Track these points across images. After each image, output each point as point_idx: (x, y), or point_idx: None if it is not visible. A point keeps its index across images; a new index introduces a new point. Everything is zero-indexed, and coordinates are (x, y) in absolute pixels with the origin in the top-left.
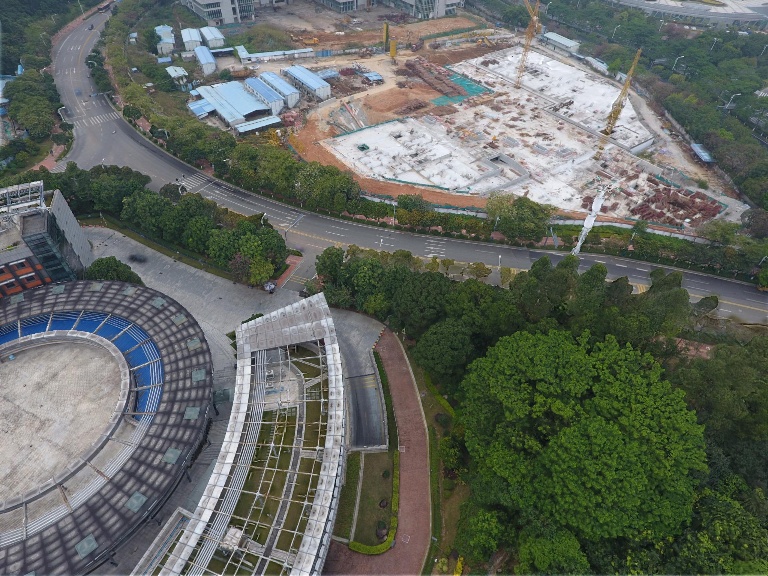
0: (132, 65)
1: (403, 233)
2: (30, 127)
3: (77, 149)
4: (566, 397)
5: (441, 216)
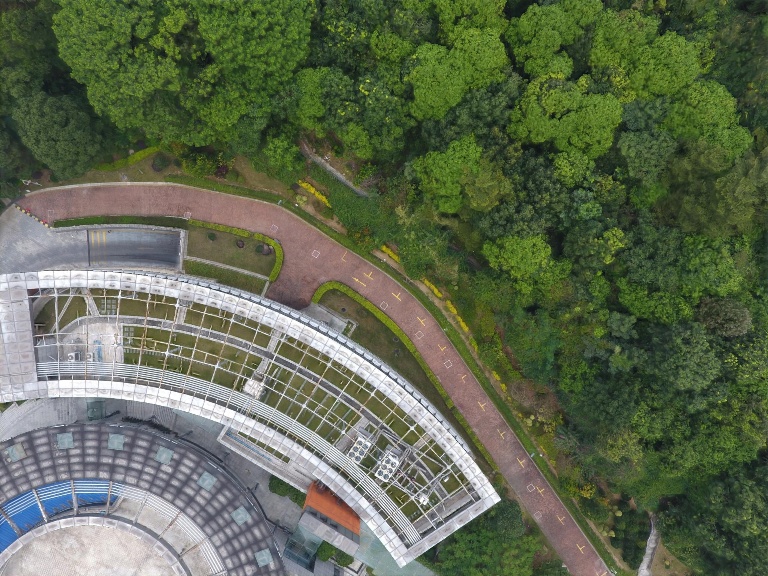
0: None
1: None
2: None
3: None
4: (160, 8)
5: None
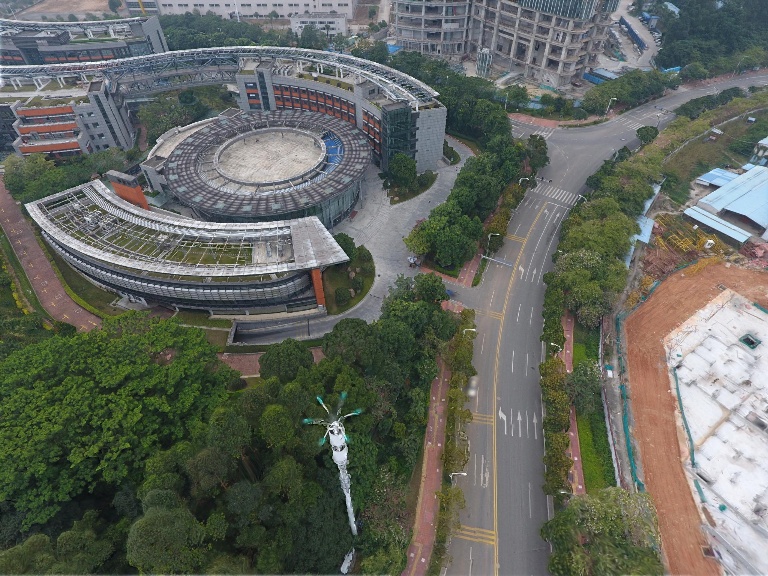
0: (759, 116)
1: None
2: (585, 98)
3: (583, 130)
4: None
5: None
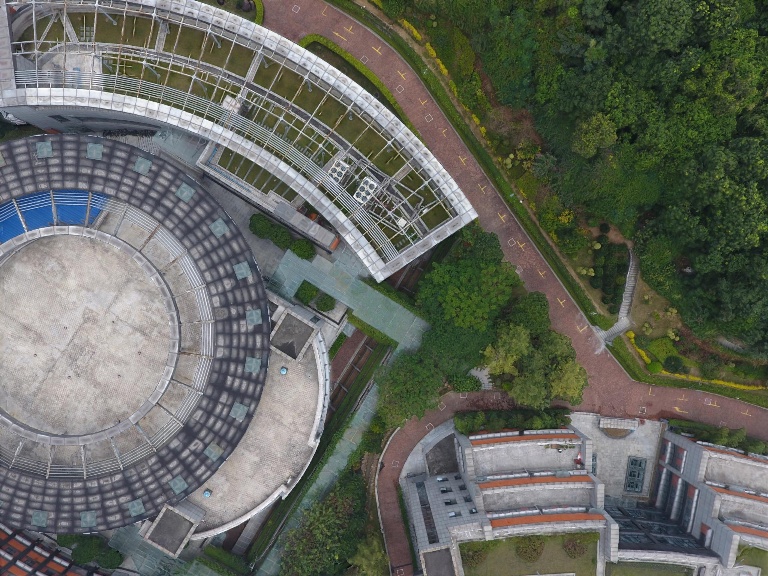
0: None
1: None
2: None
3: None
4: None
5: None
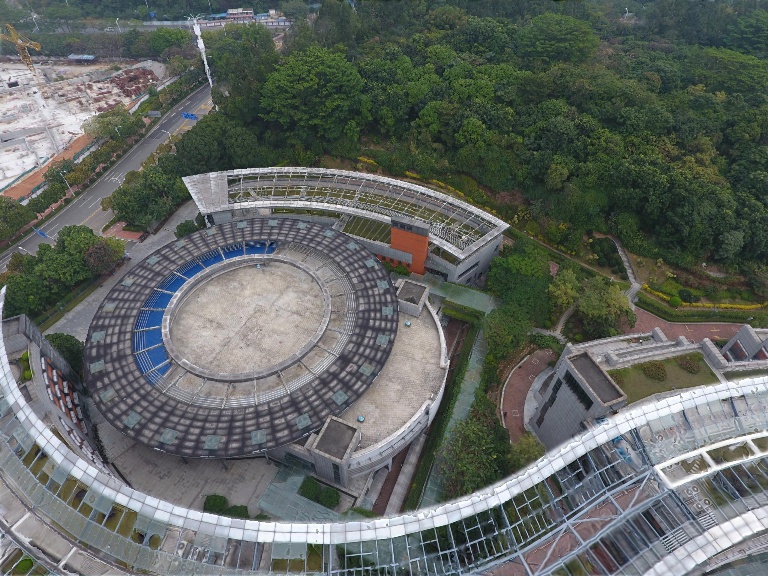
0: None
1: (86, 192)
2: None
3: None
4: None
5: (92, 156)
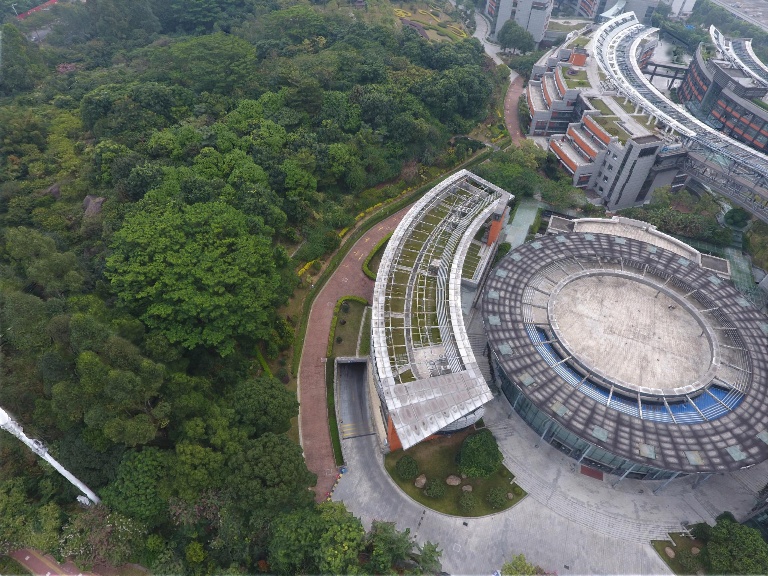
0: None
1: None
2: None
3: None
4: None
5: None
